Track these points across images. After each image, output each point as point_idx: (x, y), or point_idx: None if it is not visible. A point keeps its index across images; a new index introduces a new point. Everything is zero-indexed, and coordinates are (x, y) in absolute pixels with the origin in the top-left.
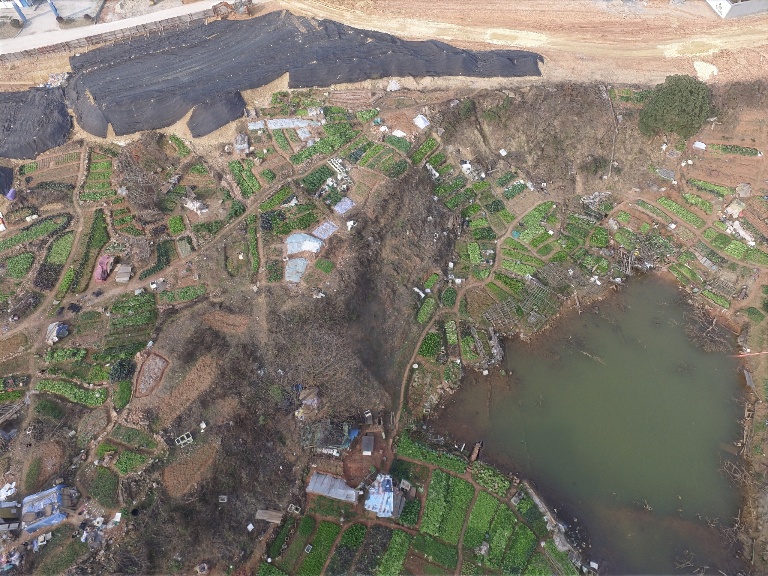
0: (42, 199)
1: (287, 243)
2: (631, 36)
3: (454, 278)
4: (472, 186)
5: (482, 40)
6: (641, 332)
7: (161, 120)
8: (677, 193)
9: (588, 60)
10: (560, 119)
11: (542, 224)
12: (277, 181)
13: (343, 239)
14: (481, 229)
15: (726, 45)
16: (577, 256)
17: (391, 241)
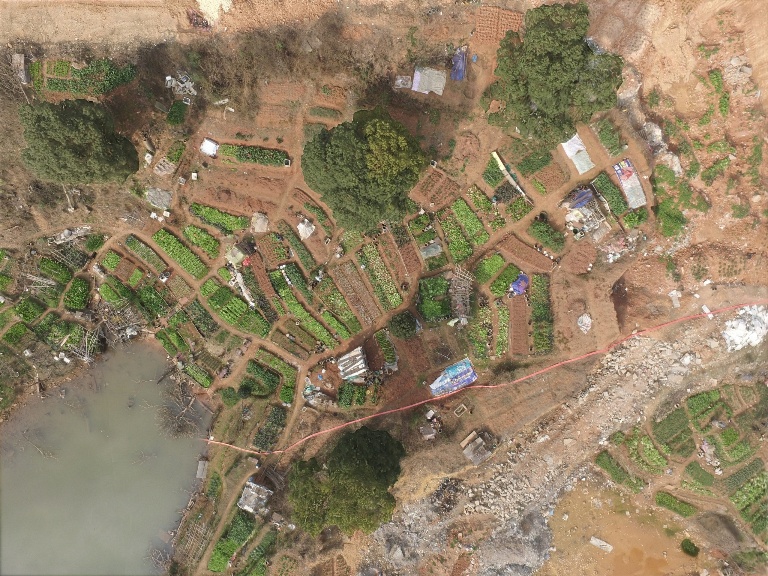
0: None
1: None
2: None
3: None
4: None
5: None
6: (110, 417)
7: None
8: (174, 227)
9: None
10: None
11: None
12: None
13: None
14: None
15: None
16: (40, 327)
17: None
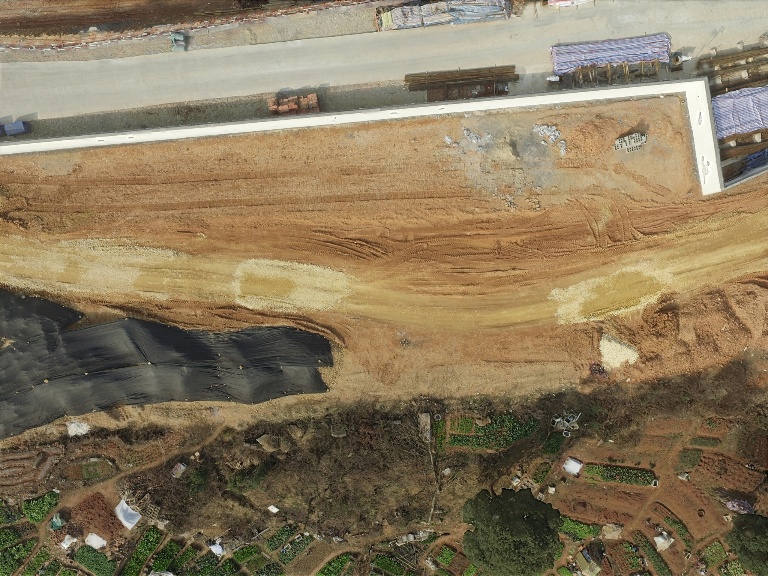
0: None
1: None
2: (508, 265)
3: None
4: (233, 556)
5: (226, 299)
6: None
7: None
8: None
9: (414, 346)
10: (352, 477)
11: None
12: None
13: None
14: None
15: (678, 282)
16: None
17: None
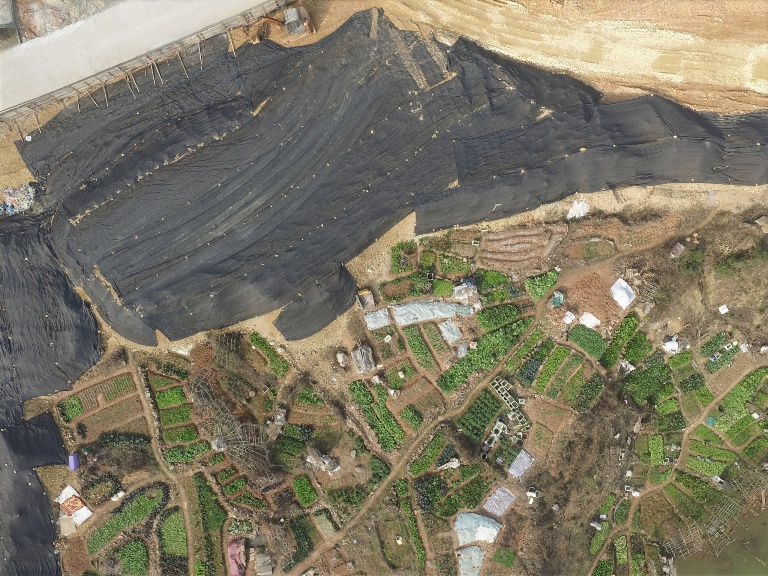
0: (118, 469)
1: (456, 531)
2: None
3: (631, 489)
4: (669, 361)
5: (737, 82)
6: None
7: (231, 315)
8: None
9: None
10: None
11: (747, 405)
12: (425, 425)
13: (523, 516)
14: (669, 416)
15: None
16: None
17: (576, 497)
